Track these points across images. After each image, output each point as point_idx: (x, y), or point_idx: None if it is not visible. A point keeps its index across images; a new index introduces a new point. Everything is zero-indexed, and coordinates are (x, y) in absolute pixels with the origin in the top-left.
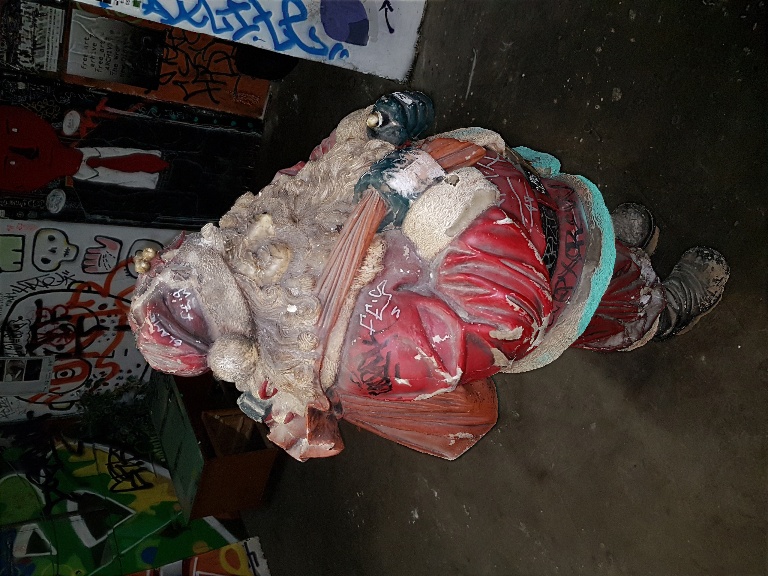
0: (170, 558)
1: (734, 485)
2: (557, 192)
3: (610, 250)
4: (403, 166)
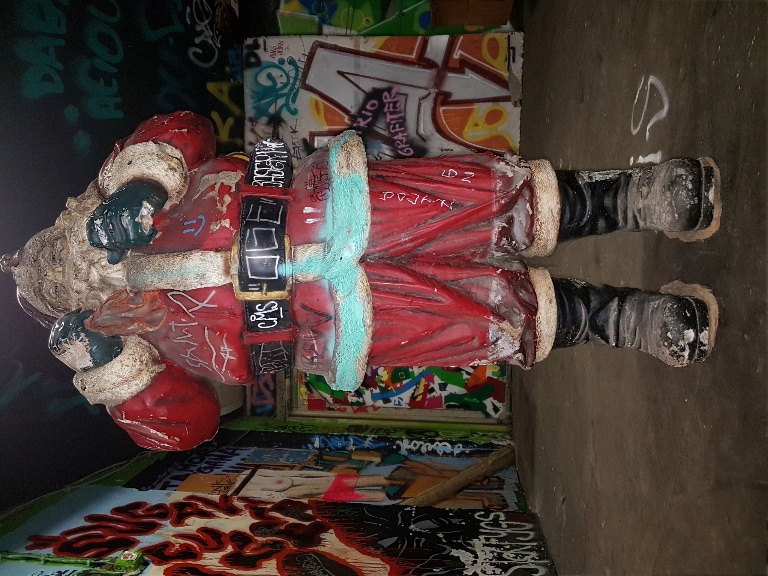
0: (441, 28)
1: (634, 441)
2: (307, 315)
3: (347, 381)
4: (58, 353)
